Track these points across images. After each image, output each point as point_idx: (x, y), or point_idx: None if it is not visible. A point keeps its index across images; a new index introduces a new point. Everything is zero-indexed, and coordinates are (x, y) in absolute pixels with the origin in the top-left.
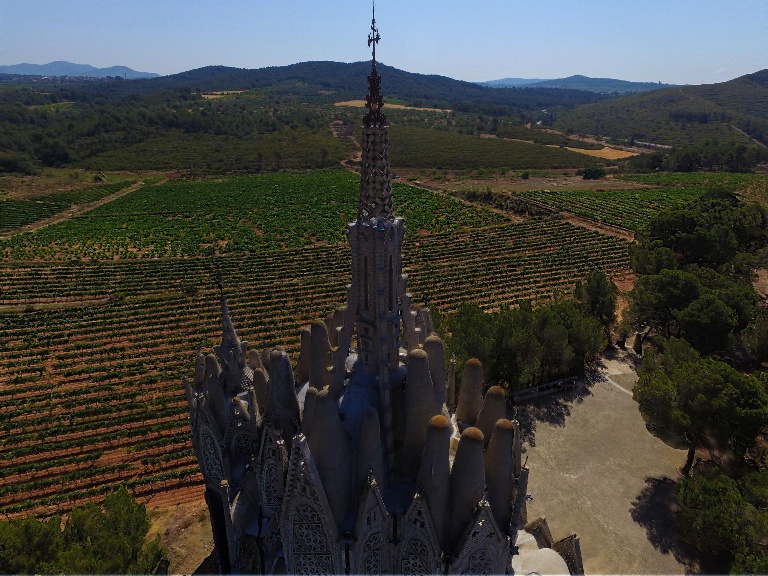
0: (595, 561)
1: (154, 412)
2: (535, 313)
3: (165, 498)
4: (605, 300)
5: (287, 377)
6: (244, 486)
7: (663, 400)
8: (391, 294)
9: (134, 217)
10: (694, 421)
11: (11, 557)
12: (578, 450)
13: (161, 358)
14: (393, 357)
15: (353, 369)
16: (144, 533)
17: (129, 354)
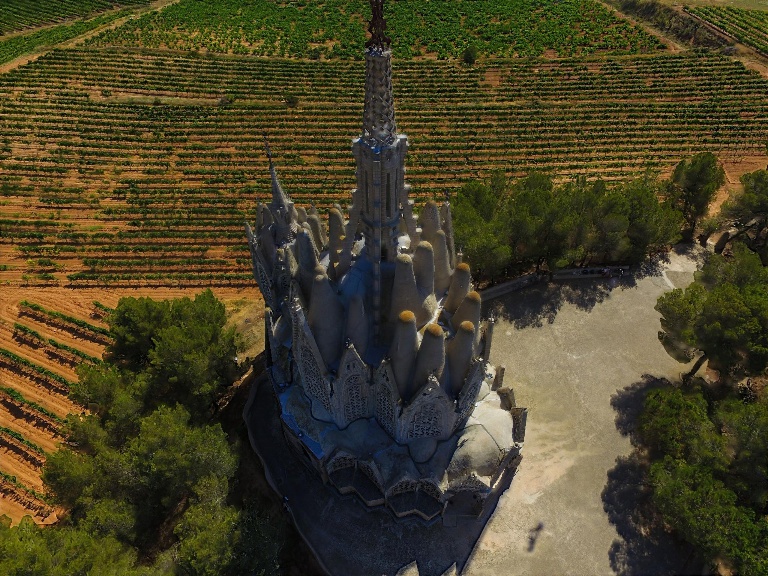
0: (558, 424)
1: (249, 221)
2: (603, 197)
3: (251, 292)
4: (702, 189)
5: (308, 249)
6: (284, 313)
7: (680, 317)
8: (389, 204)
9: (249, 1)
10: (700, 343)
11: (138, 322)
12: (592, 335)
13: (260, 169)
14: (390, 252)
15: (360, 253)
16: (223, 323)
17: (234, 162)
